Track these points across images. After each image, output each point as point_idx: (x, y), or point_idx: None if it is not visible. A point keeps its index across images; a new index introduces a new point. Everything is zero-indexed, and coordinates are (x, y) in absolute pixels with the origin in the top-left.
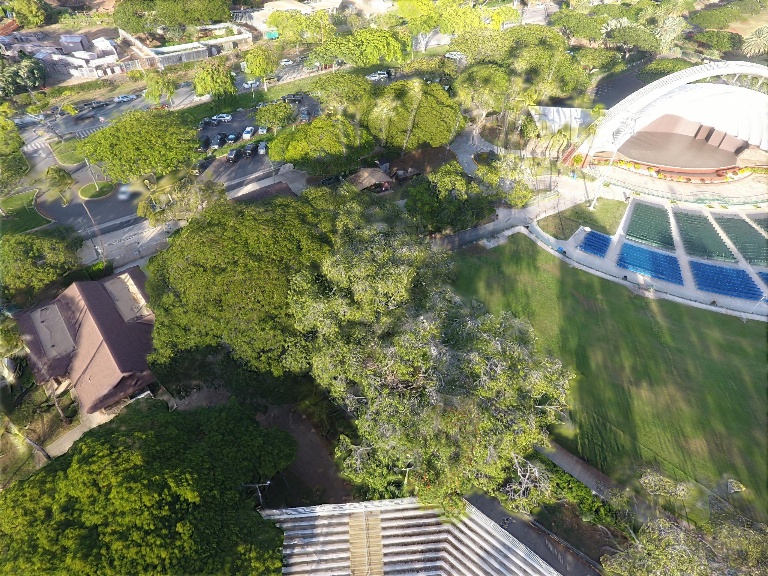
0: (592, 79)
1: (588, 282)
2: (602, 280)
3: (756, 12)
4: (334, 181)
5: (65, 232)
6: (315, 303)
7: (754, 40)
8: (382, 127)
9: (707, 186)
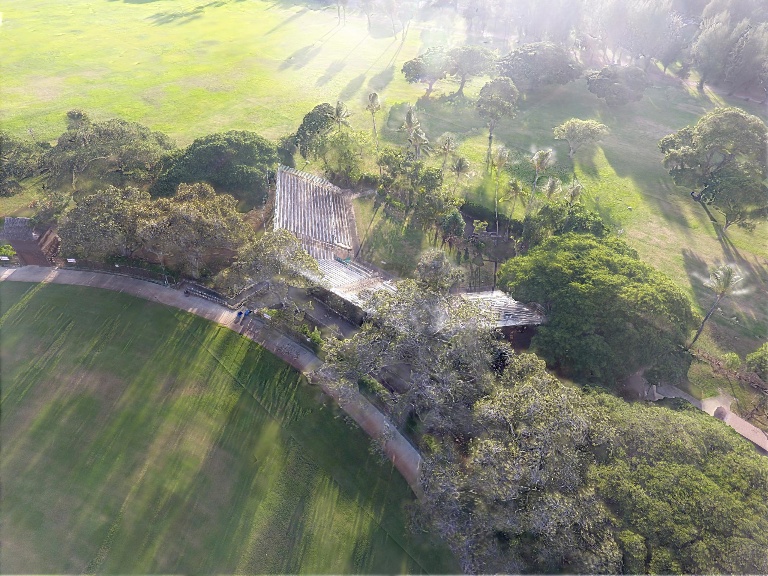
0: None
1: None
2: None
3: None
4: None
5: None
6: (571, 389)
7: None
8: None
9: None
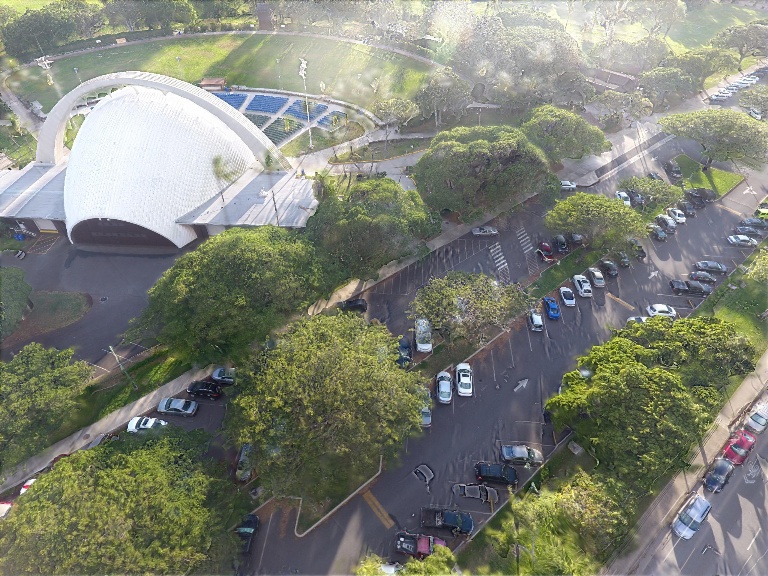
0: None
1: (354, 98)
2: (345, 100)
3: None
4: None
5: None
6: None
7: None
8: None
9: None
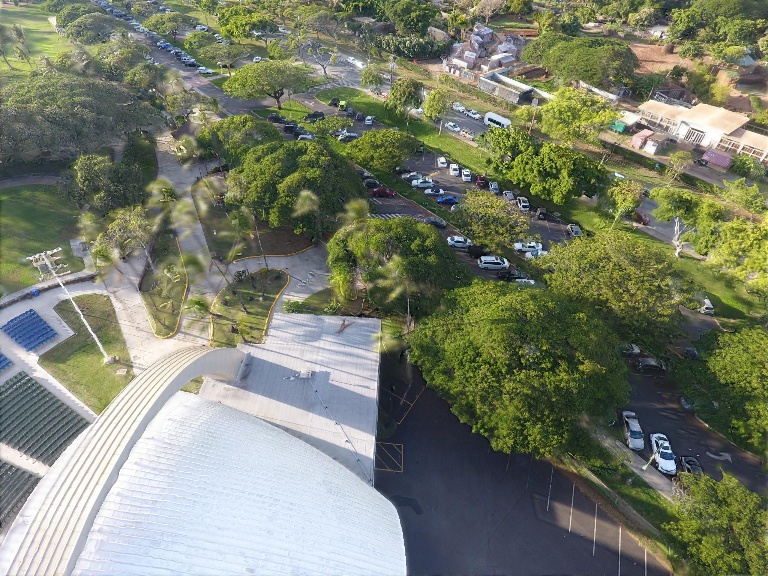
0: None
1: None
2: None
3: None
4: None
5: (163, 77)
6: None
7: None
8: None
9: None
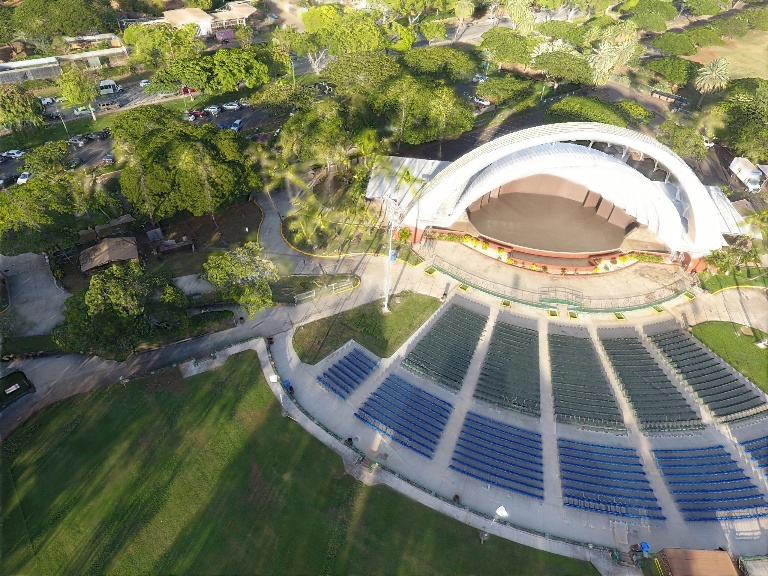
0: (496, 116)
1: (288, 447)
2: (312, 443)
3: (740, 34)
4: (76, 251)
5: None
6: None
7: (708, 73)
8: (130, 188)
9: (567, 279)
